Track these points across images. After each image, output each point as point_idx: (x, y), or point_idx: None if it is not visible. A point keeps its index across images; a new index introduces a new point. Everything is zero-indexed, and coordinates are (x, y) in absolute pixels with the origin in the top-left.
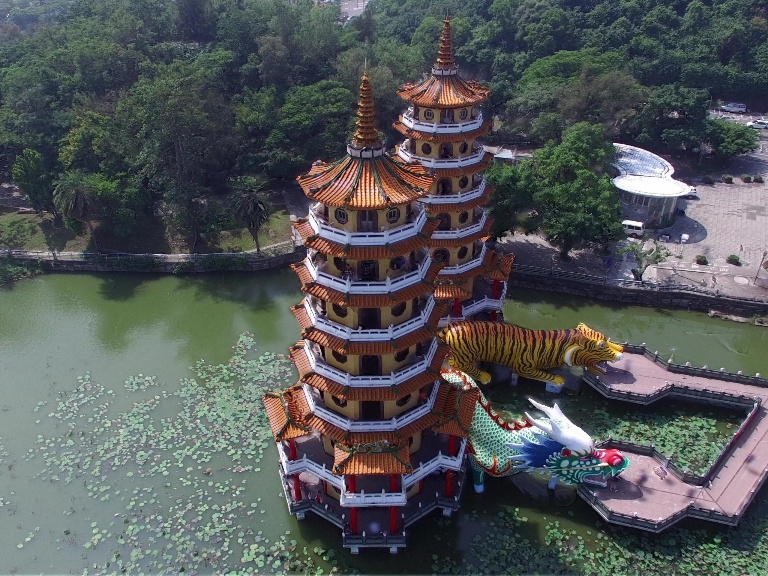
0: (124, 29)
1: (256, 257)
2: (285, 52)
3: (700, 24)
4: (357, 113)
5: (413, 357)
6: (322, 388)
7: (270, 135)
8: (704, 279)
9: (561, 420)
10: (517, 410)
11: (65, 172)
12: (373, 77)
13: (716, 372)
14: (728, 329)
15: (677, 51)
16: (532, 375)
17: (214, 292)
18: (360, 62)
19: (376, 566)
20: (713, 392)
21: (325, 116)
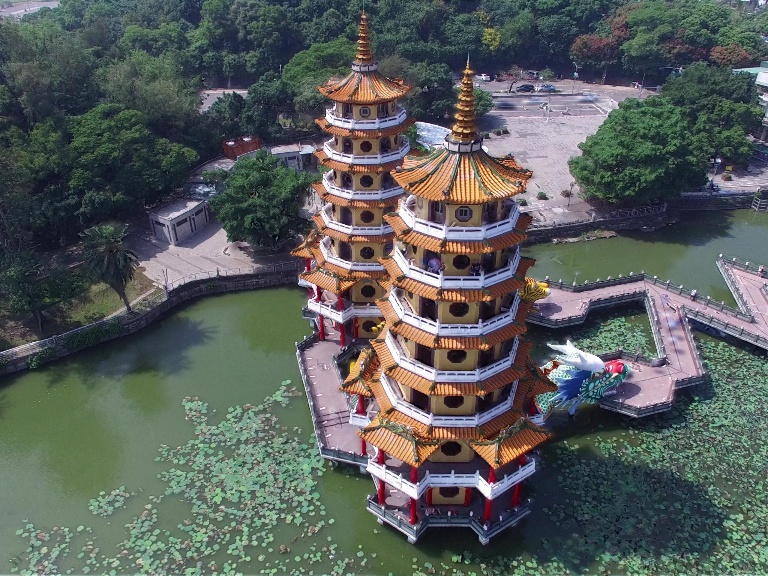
0: None
1: (131, 317)
2: None
3: (395, 9)
4: (462, 108)
5: None
6: (455, 393)
7: (73, 177)
8: (535, 216)
9: (576, 352)
10: None
11: None
12: (154, 93)
13: (606, 281)
14: (564, 251)
15: (386, 35)
16: None
17: (104, 371)
18: (130, 79)
19: (503, 546)
20: (617, 296)
21: (127, 144)
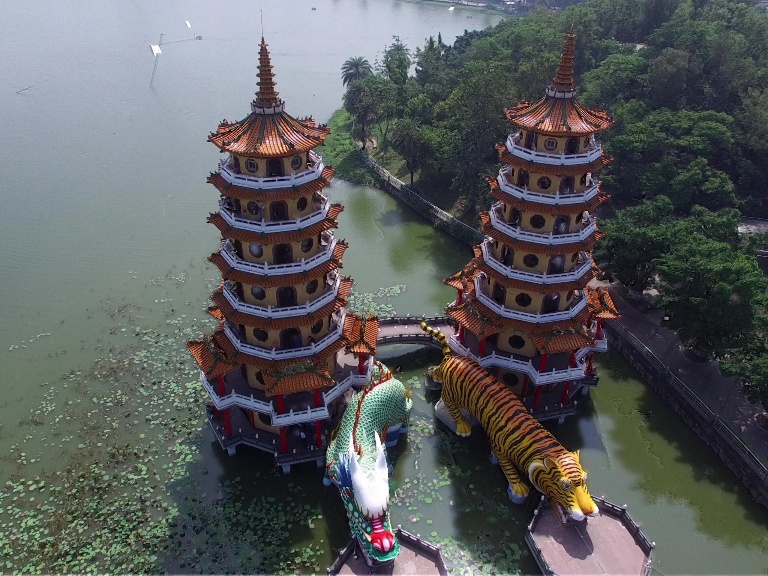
0: (571, 20)
1: None
2: (683, 69)
3: None
4: None
5: (269, 303)
6: (220, 286)
7: None
8: None
9: (376, 469)
10: (456, 477)
11: (407, 116)
12: None
13: None
14: None
15: None
16: (501, 462)
17: (436, 251)
18: None
19: None
20: None
21: (672, 146)
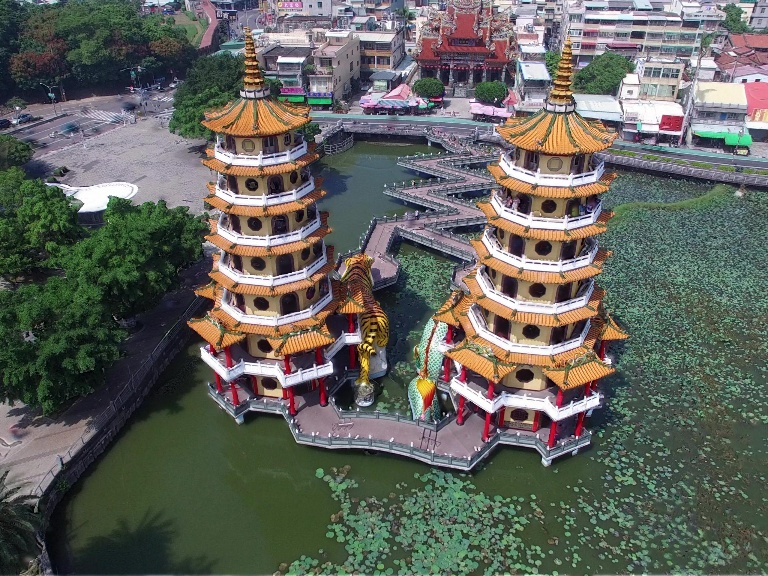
0: None
1: None
2: None
3: None
4: None
5: None
6: None
7: None
8: None
9: None
10: (405, 333)
11: None
12: None
13: None
14: None
15: None
16: None
17: None
18: None
19: None
20: None
21: None
